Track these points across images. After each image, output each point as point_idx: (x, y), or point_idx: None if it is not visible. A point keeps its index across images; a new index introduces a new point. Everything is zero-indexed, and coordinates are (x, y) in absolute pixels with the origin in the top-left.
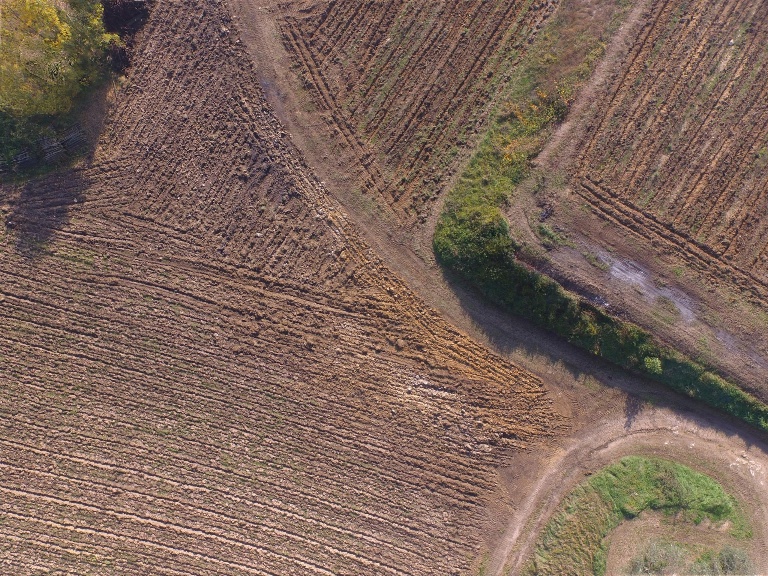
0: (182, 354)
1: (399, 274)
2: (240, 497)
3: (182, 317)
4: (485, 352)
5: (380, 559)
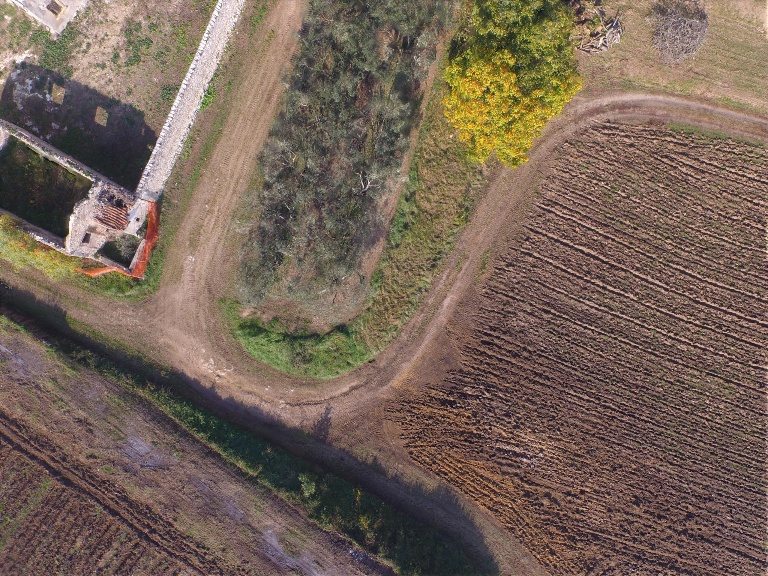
0: (765, 501)
1: (542, 571)
2: (719, 355)
3: (761, 537)
4: (464, 489)
5: (583, 283)
